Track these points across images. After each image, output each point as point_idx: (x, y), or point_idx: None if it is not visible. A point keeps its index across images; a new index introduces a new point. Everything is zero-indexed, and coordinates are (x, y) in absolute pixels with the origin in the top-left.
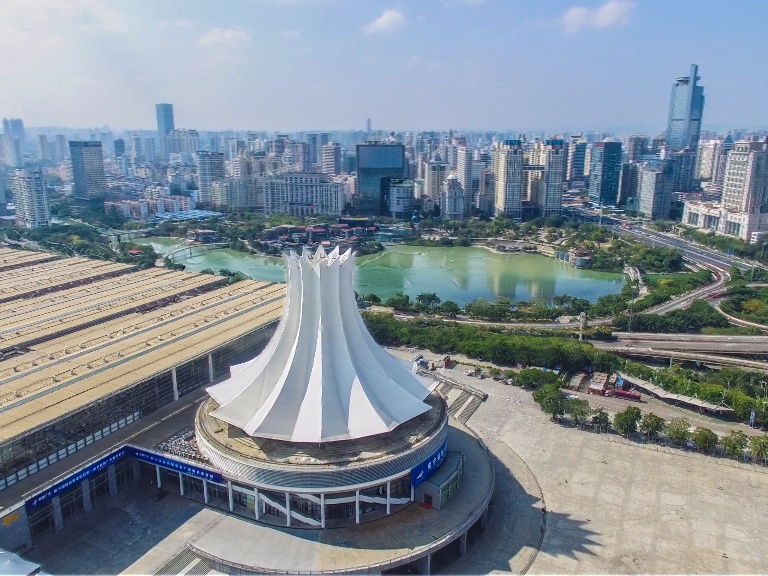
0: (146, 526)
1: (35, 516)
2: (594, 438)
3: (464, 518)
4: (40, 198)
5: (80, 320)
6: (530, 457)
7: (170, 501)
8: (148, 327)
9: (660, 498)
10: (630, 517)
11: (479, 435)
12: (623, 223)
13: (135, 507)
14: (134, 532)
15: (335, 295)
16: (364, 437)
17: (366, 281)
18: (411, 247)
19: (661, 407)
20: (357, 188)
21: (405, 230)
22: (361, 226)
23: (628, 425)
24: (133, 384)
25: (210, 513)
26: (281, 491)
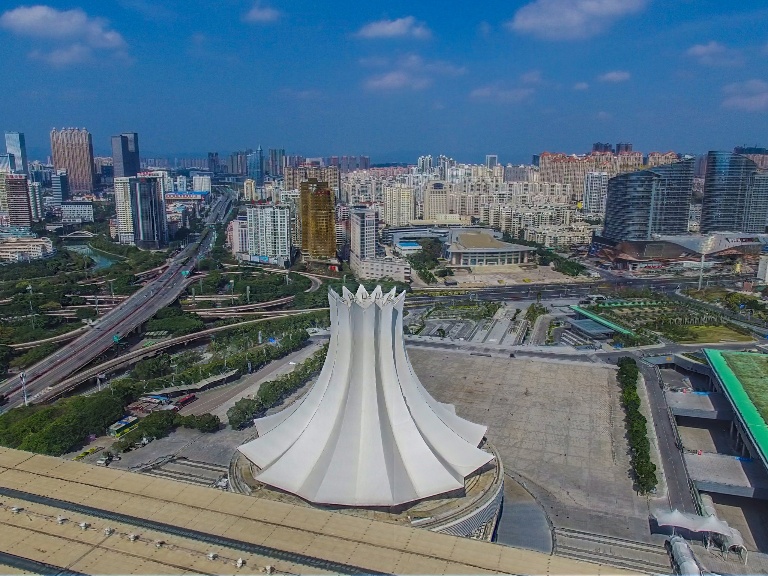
0: None
1: None
2: None
3: None
4: None
5: None
6: None
7: None
8: None
9: None
10: None
11: None
12: None
13: None
14: None
15: None
16: None
17: None
18: None
19: (208, 394)
20: None
21: None
22: None
23: None
24: None
25: None
26: None
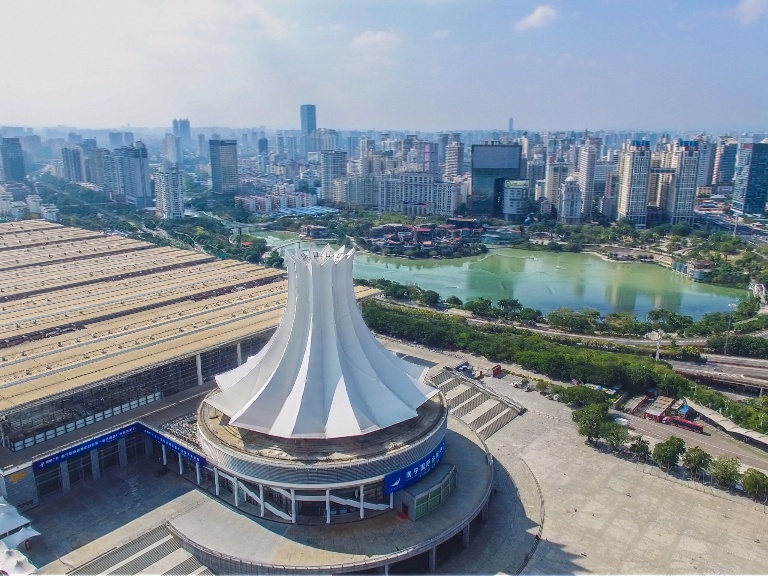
0: (138, 499)
1: (43, 477)
2: (627, 467)
3: (436, 533)
4: (176, 192)
5: (138, 304)
6: (546, 479)
7: (168, 478)
8: (191, 314)
9: (678, 542)
10: (633, 558)
11: (500, 450)
12: (765, 234)
13: (137, 480)
14: (126, 503)
15: (328, 294)
16: (337, 438)
17: (458, 283)
18: (517, 251)
19: (725, 442)
20: (470, 189)
21: (513, 233)
22: (469, 227)
23: (666, 457)
24: (148, 366)
25: (198, 494)
26: (252, 481)
